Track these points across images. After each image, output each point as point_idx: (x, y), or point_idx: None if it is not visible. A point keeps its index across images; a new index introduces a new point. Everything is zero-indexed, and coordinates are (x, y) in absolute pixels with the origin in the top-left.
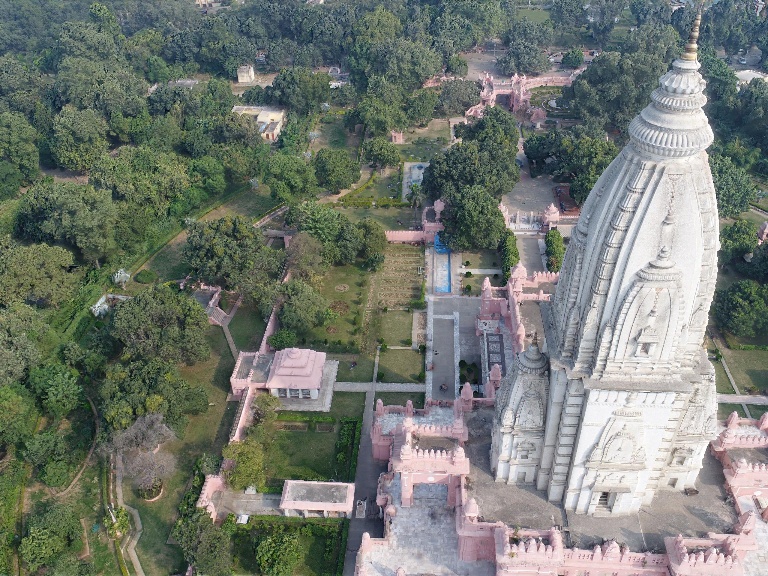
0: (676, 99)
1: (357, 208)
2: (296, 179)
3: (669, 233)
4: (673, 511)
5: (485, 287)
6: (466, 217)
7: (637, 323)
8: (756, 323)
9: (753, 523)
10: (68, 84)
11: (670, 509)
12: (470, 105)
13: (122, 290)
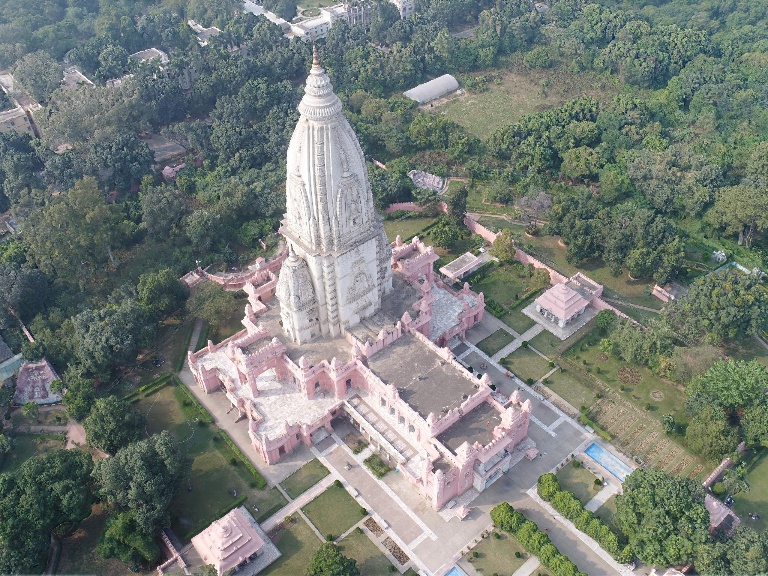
0: None
1: None
2: None
3: None
4: None
5: None
6: None
7: None
8: None
9: None
10: None
11: None
12: None
13: None
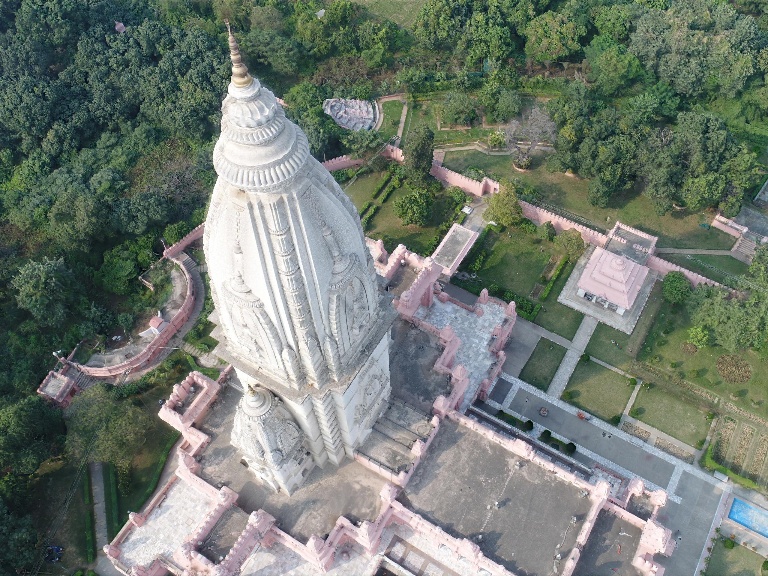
0: None
1: None
2: None
3: None
4: None
5: (656, 492)
6: None
7: None
8: None
9: None
10: None
11: None
12: None
13: None
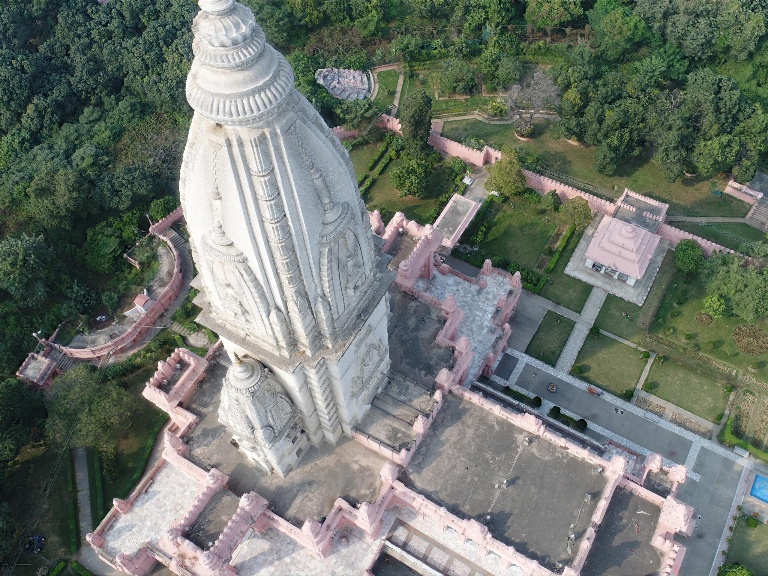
0: None
1: None
2: None
3: None
4: None
5: (675, 467)
6: None
7: None
8: None
9: None
10: None
11: None
12: None
13: None
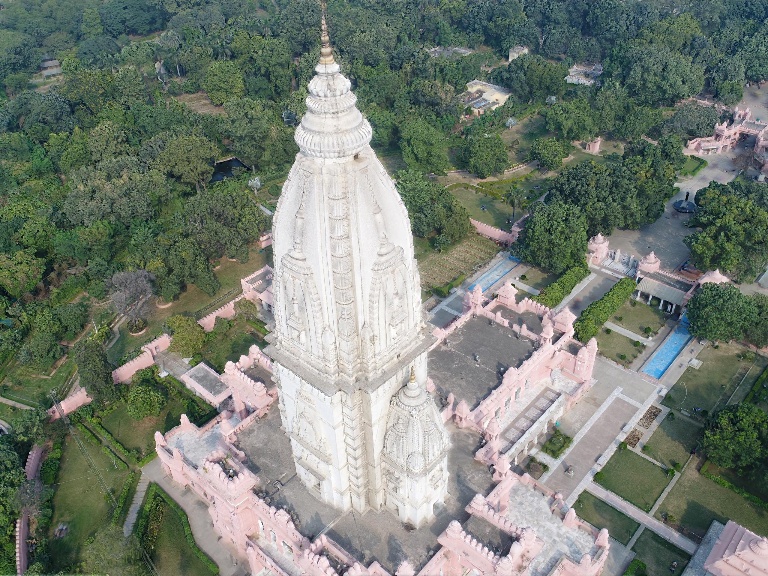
0: (311, 99)
1: (486, 196)
2: (419, 148)
3: (300, 226)
4: (376, 530)
5: None
6: (529, 229)
7: (288, 305)
8: (739, 458)
9: (403, 574)
10: (338, 28)
11: (375, 527)
12: (696, 135)
13: (254, 194)
